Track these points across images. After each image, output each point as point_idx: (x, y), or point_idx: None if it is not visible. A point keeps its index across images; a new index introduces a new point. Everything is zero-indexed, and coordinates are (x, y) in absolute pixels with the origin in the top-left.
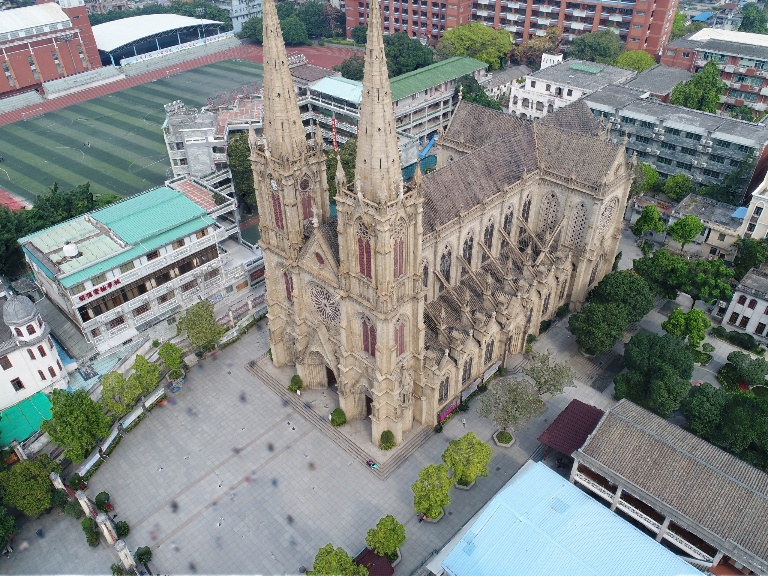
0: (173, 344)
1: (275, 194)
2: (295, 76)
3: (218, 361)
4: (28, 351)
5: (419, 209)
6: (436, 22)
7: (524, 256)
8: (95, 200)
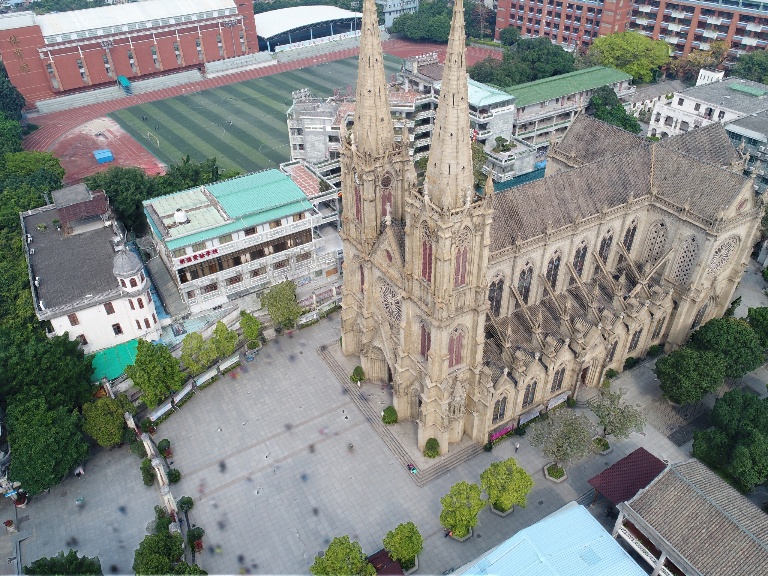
0: (253, 316)
1: (358, 188)
2: (423, 74)
3: (294, 340)
4: (129, 301)
5: (487, 220)
6: (589, 28)
7: None
8: (220, 174)
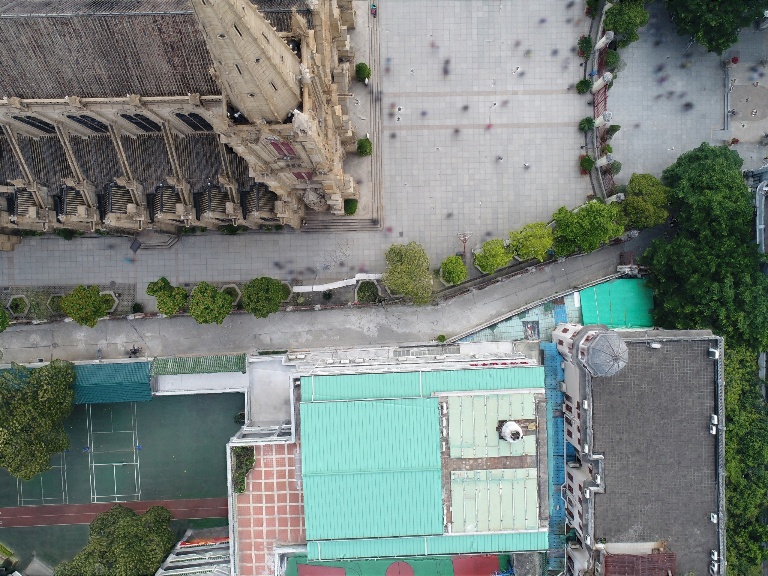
0: (449, 269)
1: None
2: None
3: None
4: None
5: None
6: None
7: None
8: None
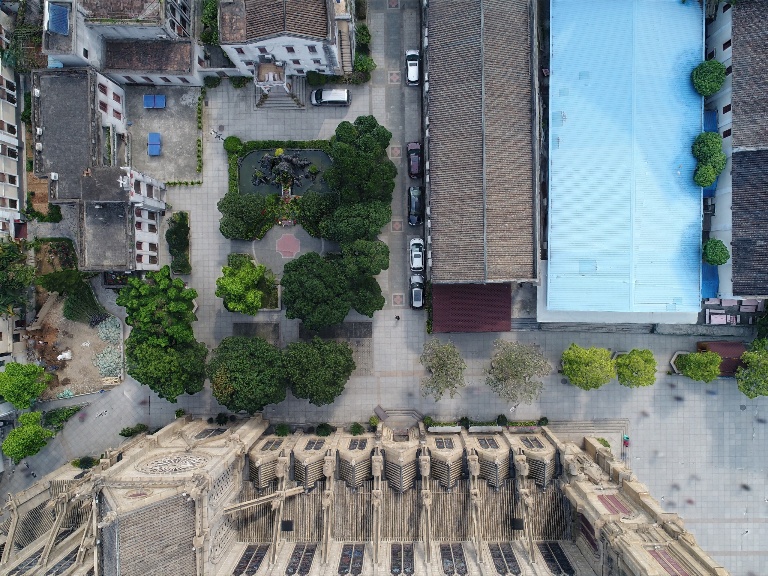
0: None
1: None
2: None
3: None
4: None
5: None
6: None
7: (296, 514)
8: None
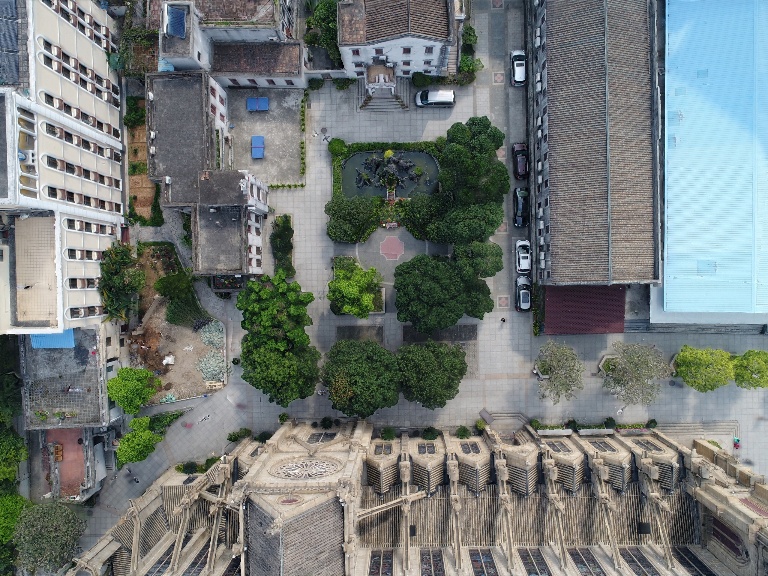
0: None
1: None
2: None
3: None
4: None
5: None
6: None
7: (418, 519)
8: None
